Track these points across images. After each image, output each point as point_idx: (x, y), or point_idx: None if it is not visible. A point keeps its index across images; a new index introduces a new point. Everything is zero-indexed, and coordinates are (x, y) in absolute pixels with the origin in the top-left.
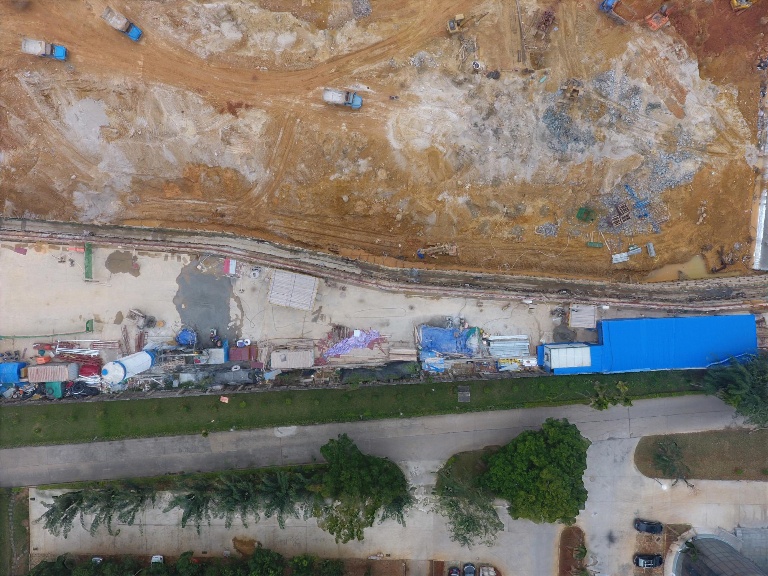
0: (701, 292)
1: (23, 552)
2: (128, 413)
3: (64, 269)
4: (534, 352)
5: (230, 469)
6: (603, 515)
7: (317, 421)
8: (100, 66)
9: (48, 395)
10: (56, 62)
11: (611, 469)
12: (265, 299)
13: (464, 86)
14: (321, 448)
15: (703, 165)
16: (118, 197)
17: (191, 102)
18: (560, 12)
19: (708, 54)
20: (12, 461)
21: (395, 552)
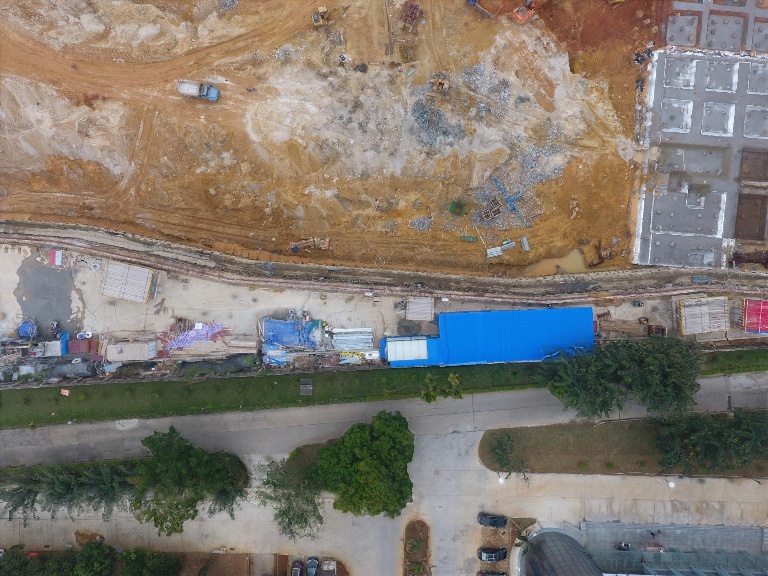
0: (557, 286)
1: None
2: None
3: None
4: (378, 345)
5: (71, 462)
6: (448, 509)
7: (157, 414)
8: None
9: None
10: None
11: (455, 463)
12: None
13: None
14: (142, 440)
15: (572, 159)
16: None
17: (45, 94)
18: (428, 5)
19: (585, 48)
20: None
21: (239, 546)
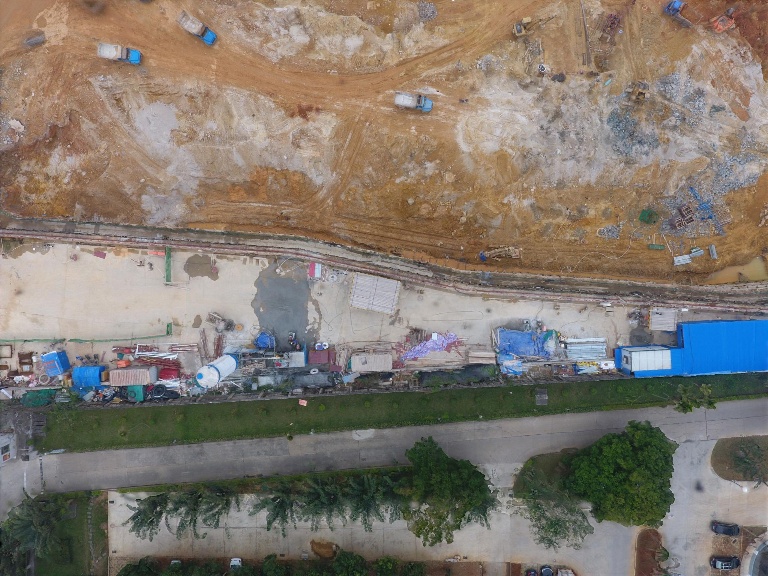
0: None
1: (102, 555)
2: (207, 416)
3: (143, 273)
4: (611, 355)
5: (308, 472)
6: (680, 517)
7: (396, 424)
8: (173, 70)
9: (130, 398)
10: (129, 66)
11: (688, 471)
12: (343, 302)
13: (530, 89)
14: (409, 451)
15: (767, 167)
16: (183, 200)
17: (263, 106)
18: (625, 15)
19: None
20: (91, 464)
21: (472, 554)
